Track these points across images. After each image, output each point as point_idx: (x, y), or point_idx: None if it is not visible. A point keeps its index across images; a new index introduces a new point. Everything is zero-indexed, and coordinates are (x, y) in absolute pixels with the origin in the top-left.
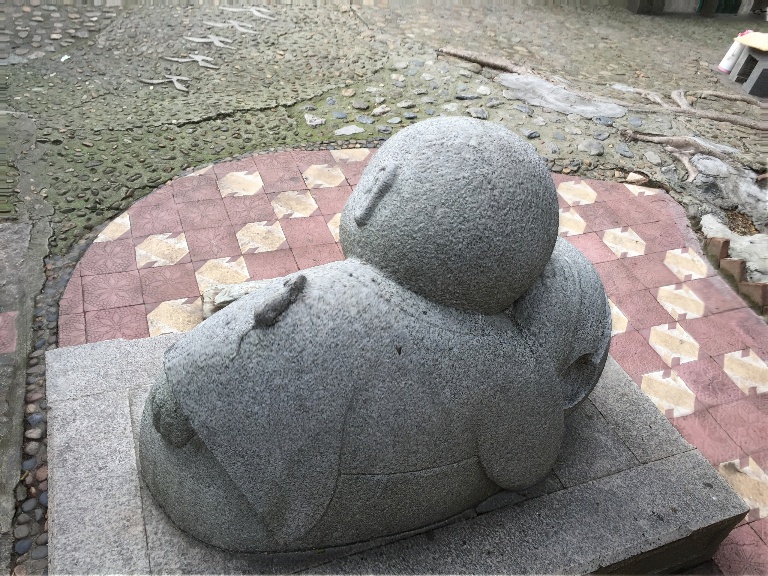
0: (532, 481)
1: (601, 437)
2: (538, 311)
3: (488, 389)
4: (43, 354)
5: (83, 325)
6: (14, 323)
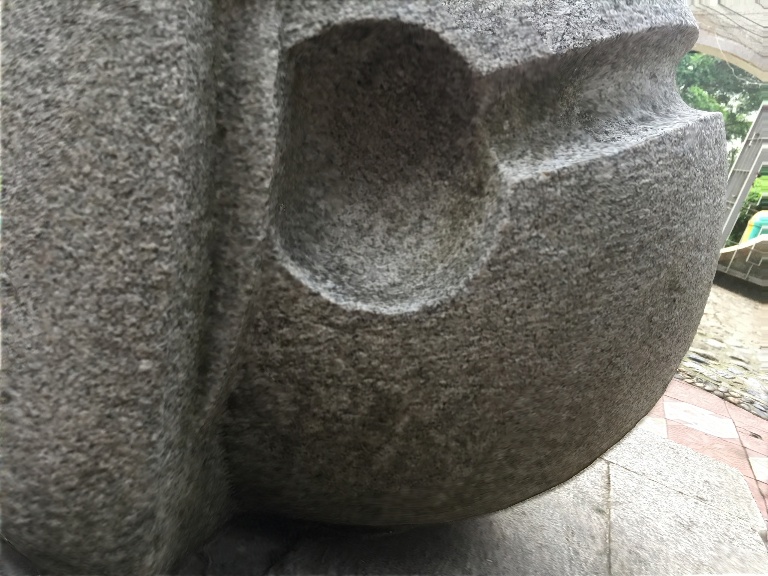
0: (2, 470)
1: None
2: None
3: None
4: None
5: None
6: None
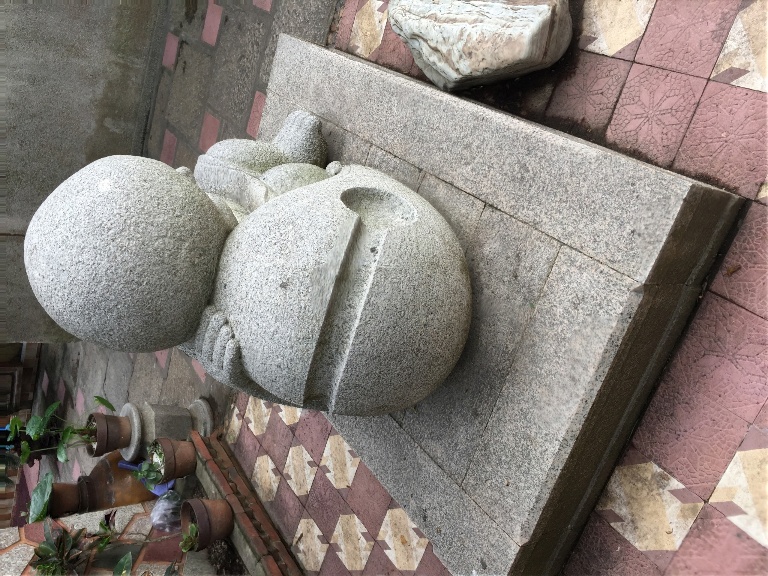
0: None
1: (461, 435)
2: None
3: None
4: None
5: None
6: None
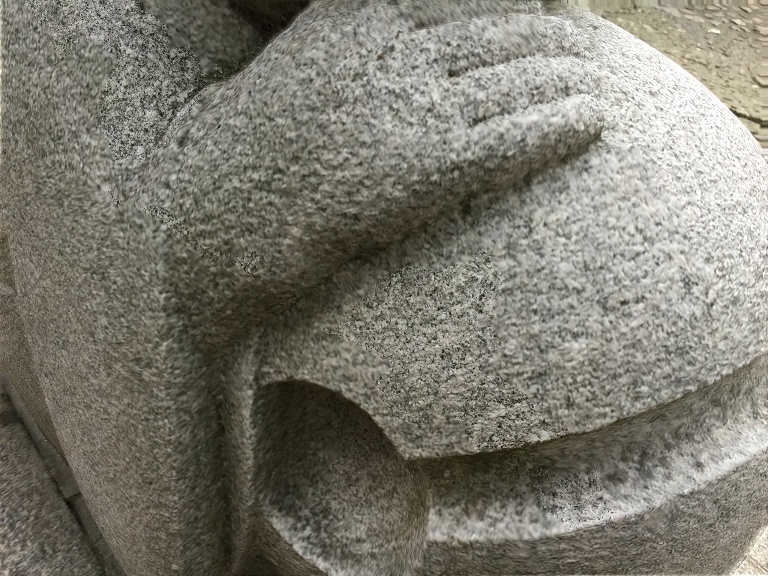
0: None
1: None
2: (265, 51)
3: (8, 90)
4: None
5: None
6: None
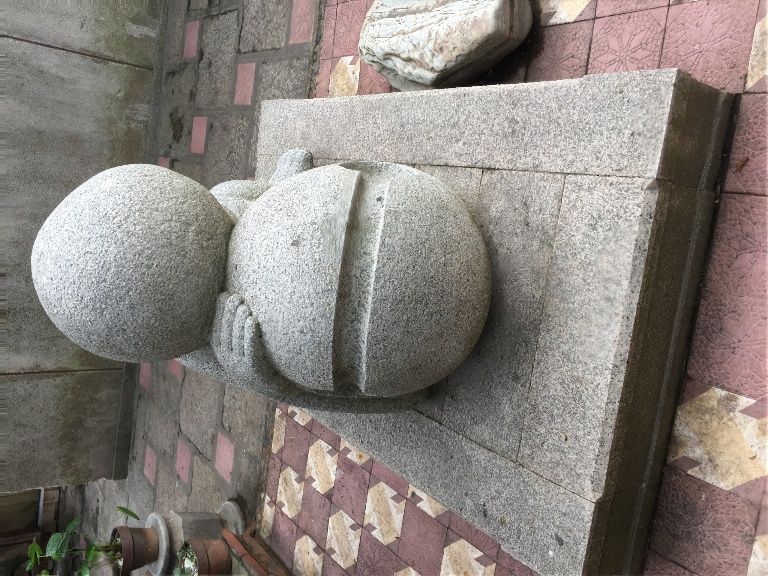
0: None
1: (506, 407)
2: None
3: None
4: (319, 50)
5: (334, 22)
6: (313, 7)
